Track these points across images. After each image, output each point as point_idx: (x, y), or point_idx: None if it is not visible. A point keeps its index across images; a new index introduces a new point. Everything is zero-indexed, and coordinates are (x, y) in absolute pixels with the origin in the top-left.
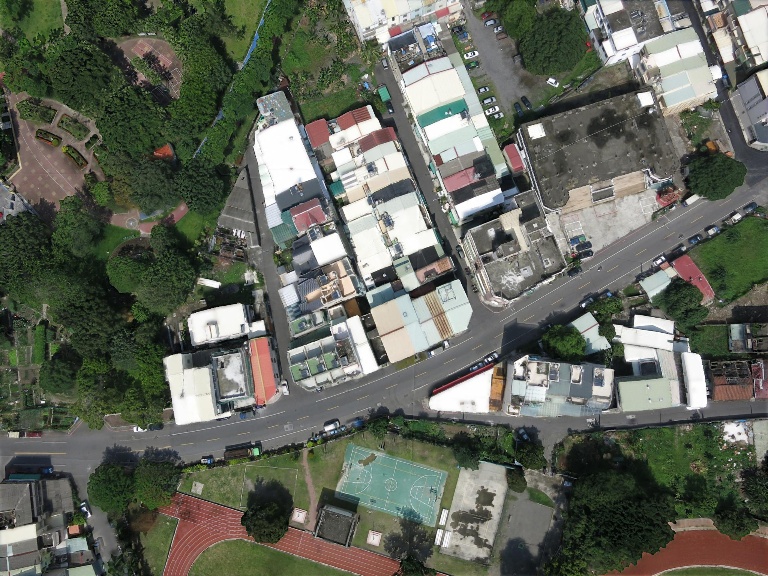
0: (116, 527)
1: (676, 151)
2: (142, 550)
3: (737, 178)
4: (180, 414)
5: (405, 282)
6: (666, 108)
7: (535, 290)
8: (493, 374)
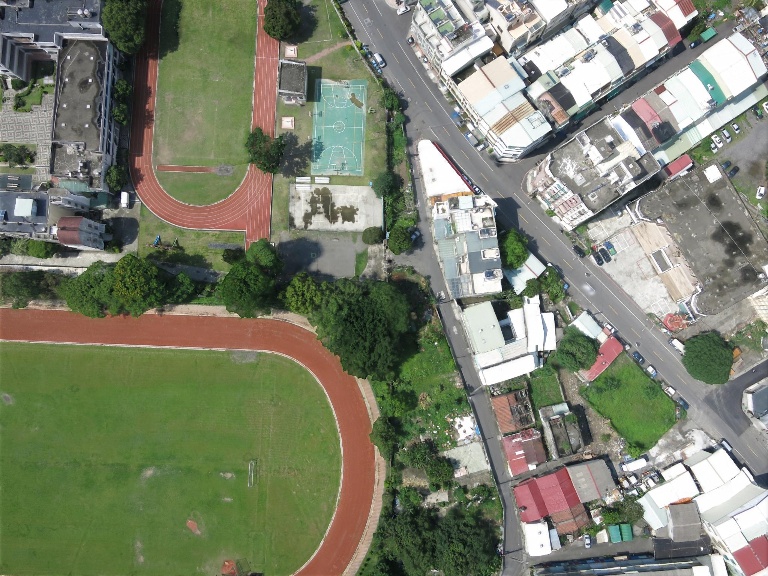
0: None
1: (721, 324)
2: None
3: (713, 375)
4: None
5: (534, 85)
6: (765, 297)
7: (552, 219)
8: (466, 192)
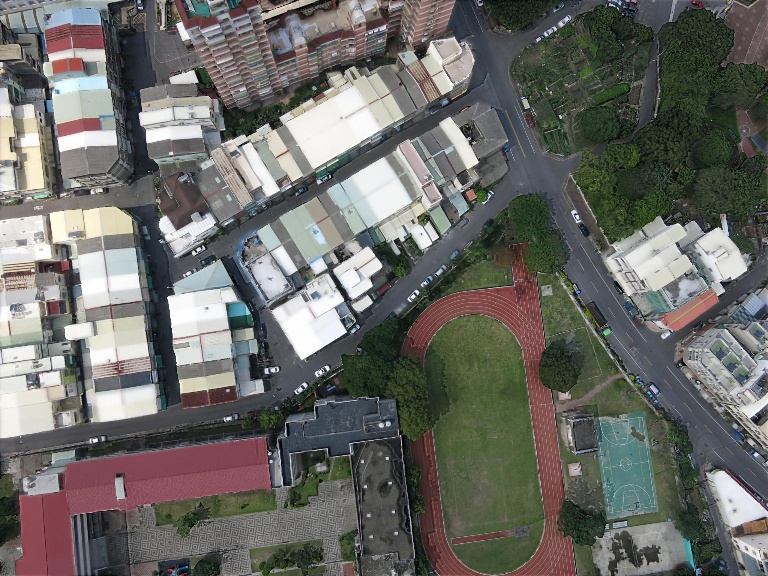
0: (488, 232)
1: None
2: (473, 263)
3: None
4: (636, 256)
5: None
6: None
7: None
8: (767, 518)
